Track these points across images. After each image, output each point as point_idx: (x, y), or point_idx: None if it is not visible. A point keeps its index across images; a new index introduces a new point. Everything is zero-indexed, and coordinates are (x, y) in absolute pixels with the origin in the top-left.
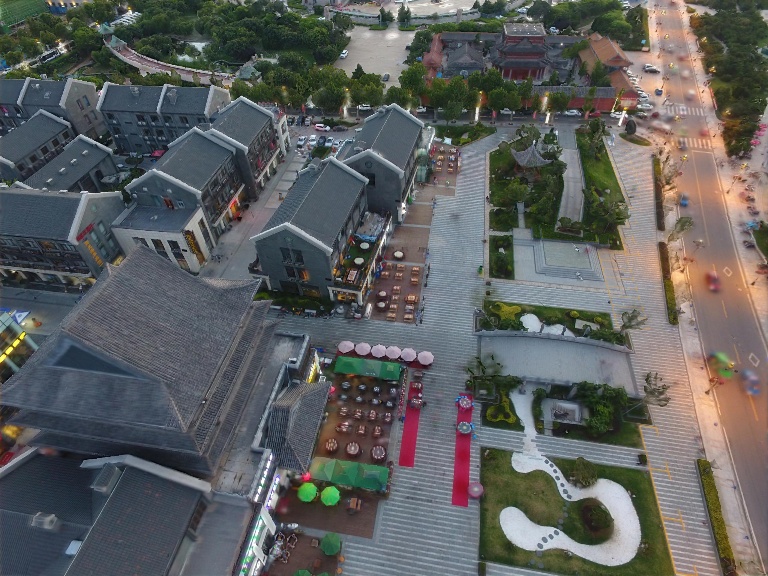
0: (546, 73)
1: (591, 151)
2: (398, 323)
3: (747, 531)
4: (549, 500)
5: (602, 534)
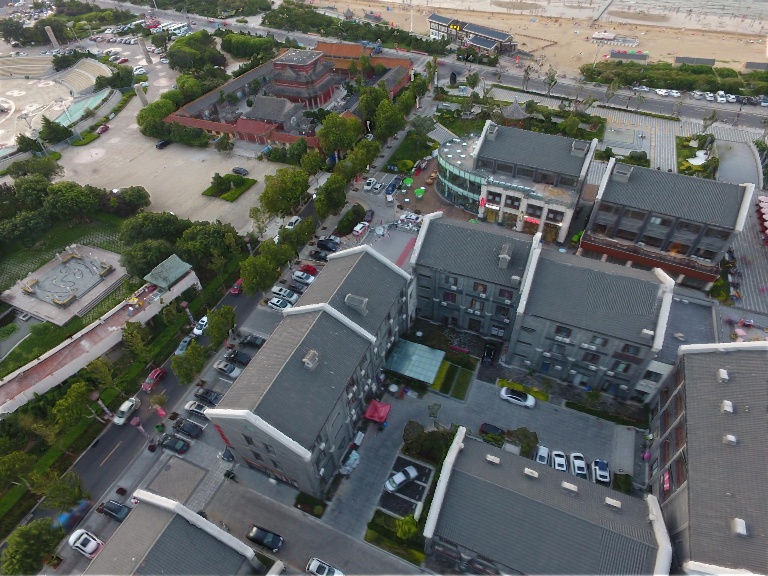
0: None
1: (486, 97)
2: None
3: None
4: None
5: None
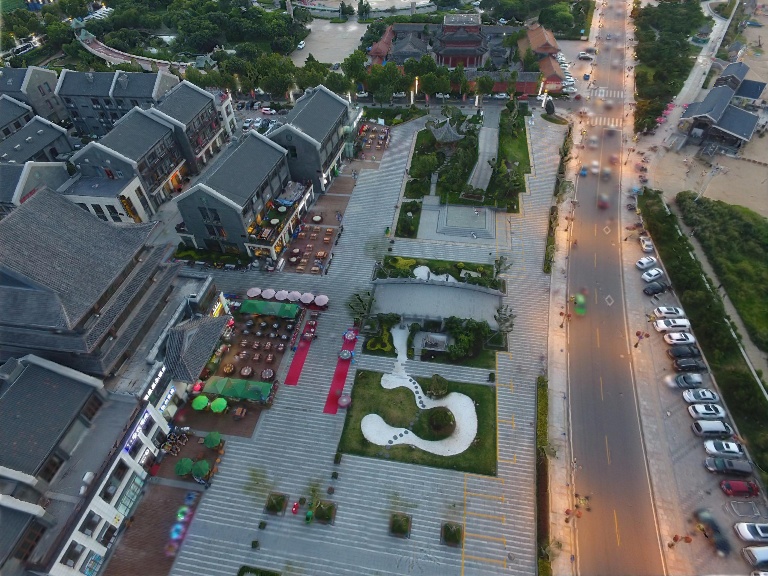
0: (485, 61)
1: (508, 129)
2: (306, 274)
3: (566, 429)
4: (405, 408)
5: (443, 432)
